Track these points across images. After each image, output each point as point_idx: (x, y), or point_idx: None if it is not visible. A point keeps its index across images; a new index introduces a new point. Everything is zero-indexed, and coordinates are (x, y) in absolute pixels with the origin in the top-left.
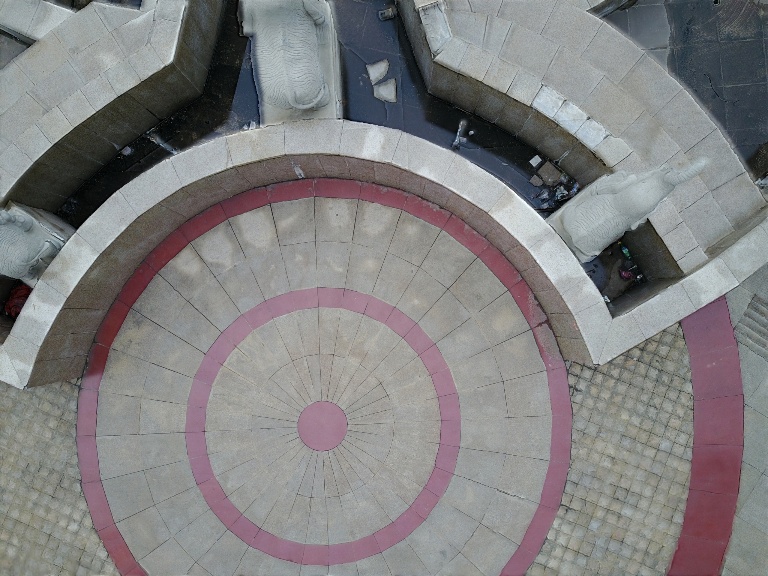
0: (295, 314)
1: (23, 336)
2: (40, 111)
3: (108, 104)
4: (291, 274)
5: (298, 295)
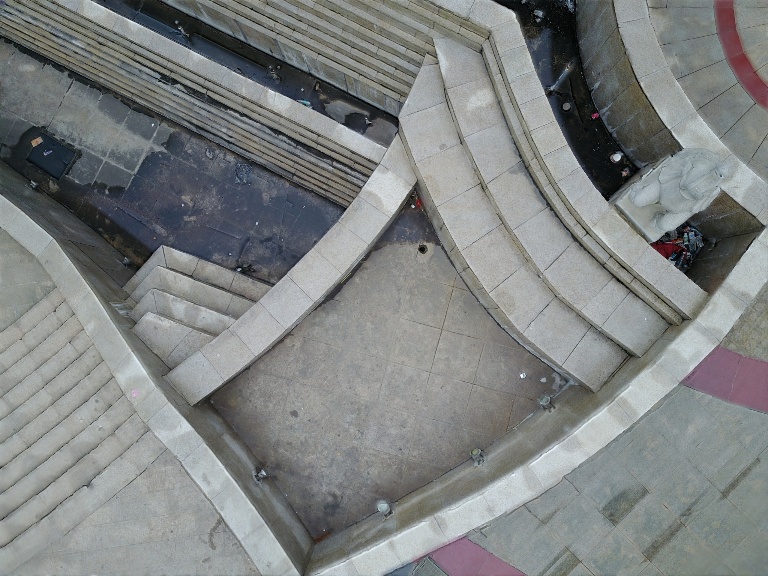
0: (736, 8)
1: (761, 204)
2: (509, 175)
3: (540, 82)
4: (696, 3)
5: (718, 1)
